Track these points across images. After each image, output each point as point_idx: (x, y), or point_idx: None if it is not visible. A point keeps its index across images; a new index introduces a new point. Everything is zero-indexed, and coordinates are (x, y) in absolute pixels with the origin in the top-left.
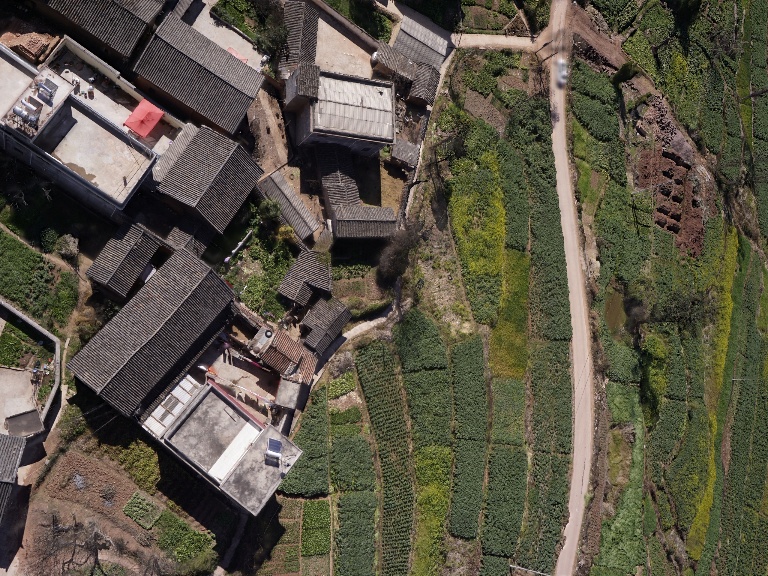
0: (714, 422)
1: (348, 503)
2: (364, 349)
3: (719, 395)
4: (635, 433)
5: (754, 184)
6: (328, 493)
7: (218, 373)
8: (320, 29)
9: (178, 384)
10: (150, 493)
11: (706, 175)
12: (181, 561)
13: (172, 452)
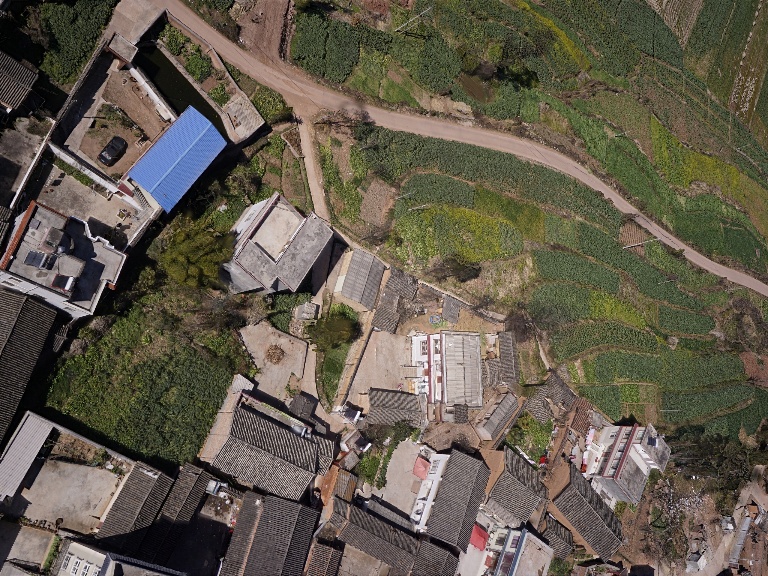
0: (524, 5)
1: None
2: None
3: None
4: None
5: None
6: None
7: (578, 462)
8: (361, 382)
9: None
10: None
11: None
12: (650, 478)
13: None
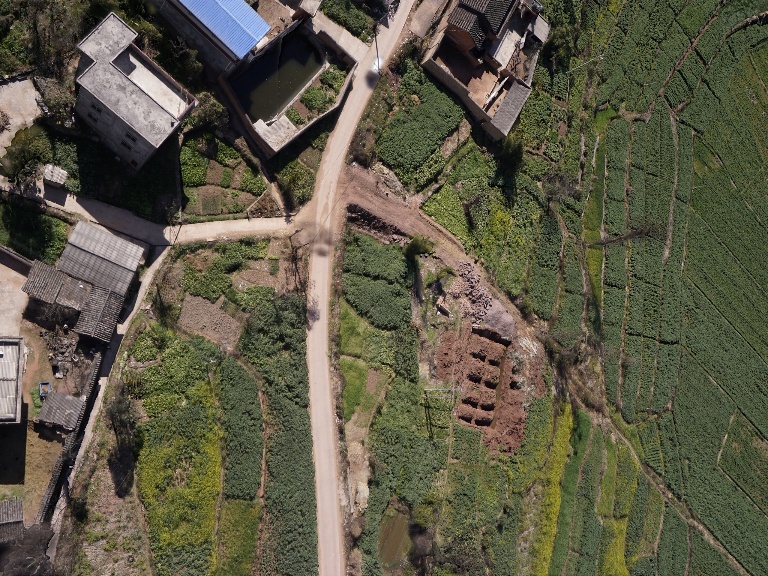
0: None
1: None
2: None
3: None
4: None
5: (601, 343)
6: None
7: None
8: None
9: None
10: None
11: (531, 349)
12: None
13: None
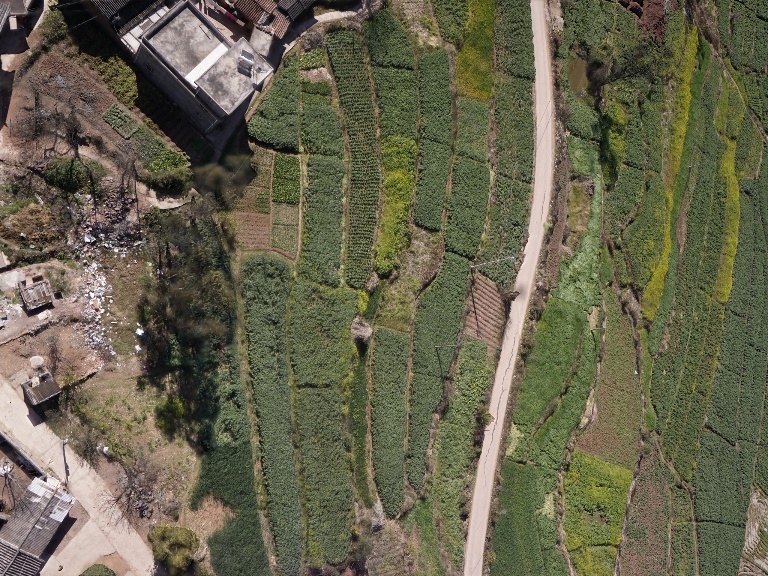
0: (670, 199)
1: (317, 163)
2: (335, 33)
3: (676, 178)
4: (594, 186)
5: None
6: (298, 152)
7: None
8: None
9: (156, 12)
10: (128, 107)
11: None
12: (157, 172)
13: (149, 77)
